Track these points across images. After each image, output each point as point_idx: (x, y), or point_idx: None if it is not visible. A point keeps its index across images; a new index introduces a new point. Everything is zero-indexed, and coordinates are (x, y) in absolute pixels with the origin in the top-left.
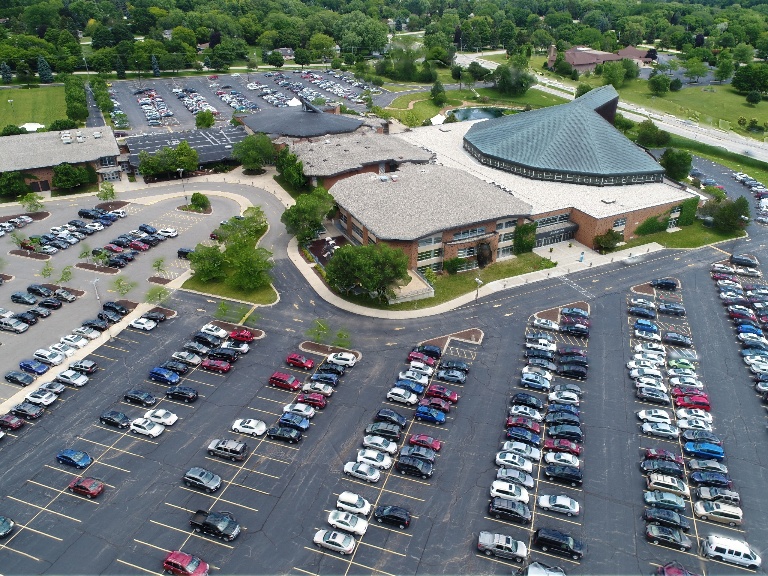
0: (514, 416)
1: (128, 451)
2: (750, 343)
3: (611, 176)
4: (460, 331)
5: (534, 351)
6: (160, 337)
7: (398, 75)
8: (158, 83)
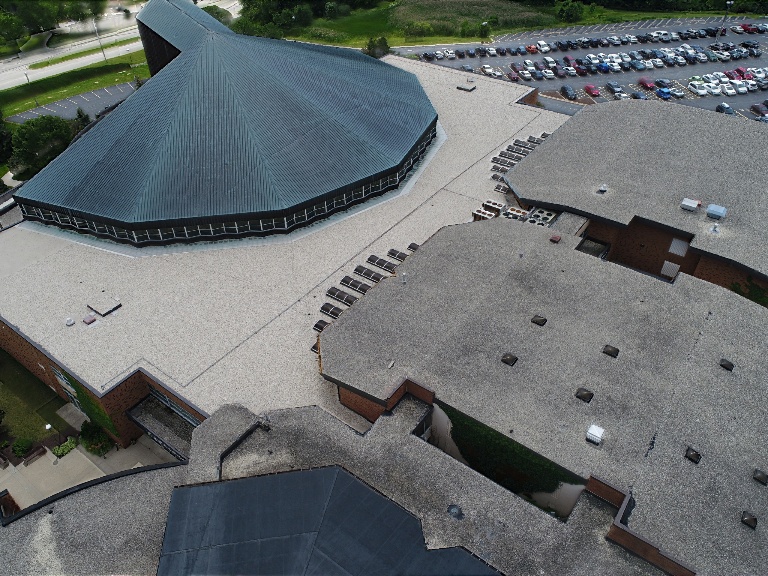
0: None
1: None
2: (628, 65)
3: None
4: None
5: None
6: None
7: None
8: None
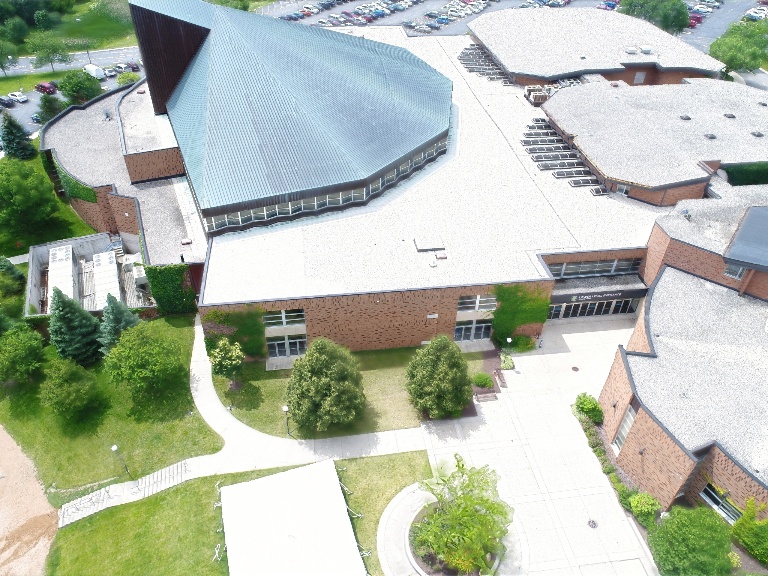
0: (564, 0)
1: None
2: (392, 8)
3: None
4: None
5: None
6: None
7: None
8: None
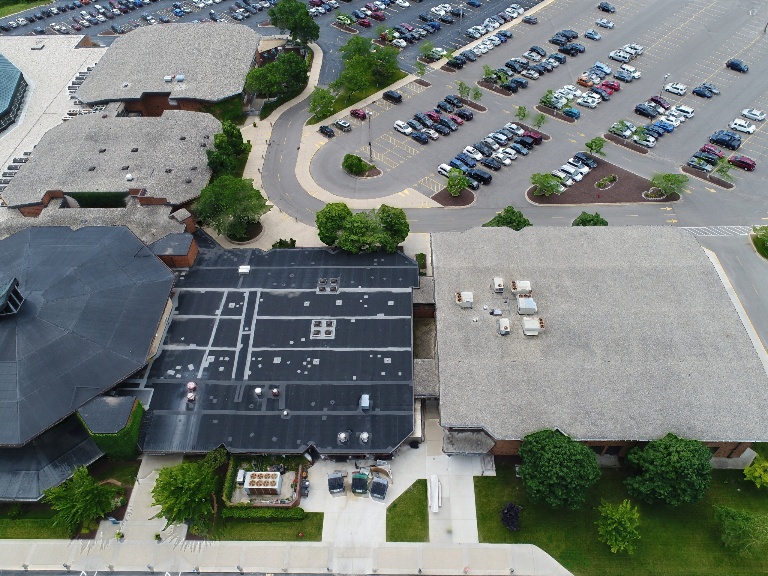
0: None
1: (453, 5)
2: None
3: None
4: (269, 27)
5: (251, 10)
6: (431, 47)
7: None
8: None
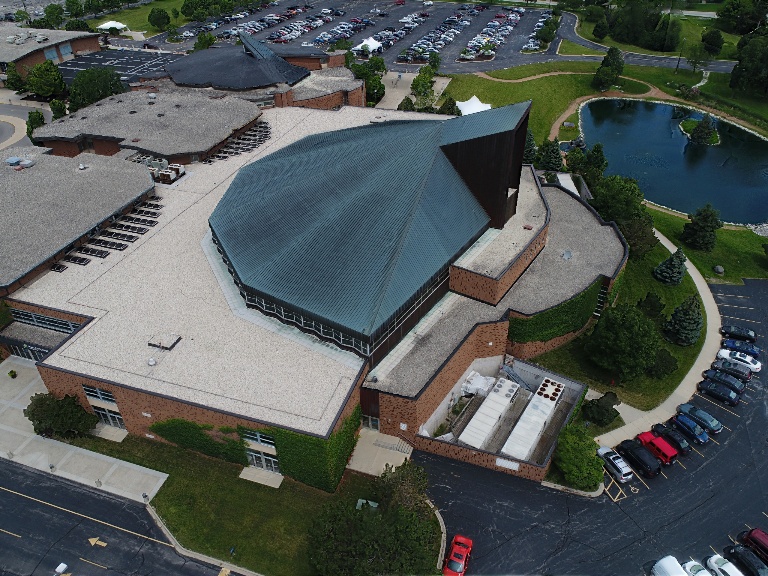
0: None
1: None
2: None
3: (258, 294)
4: None
5: None
6: None
7: (604, 30)
8: (339, 1)
